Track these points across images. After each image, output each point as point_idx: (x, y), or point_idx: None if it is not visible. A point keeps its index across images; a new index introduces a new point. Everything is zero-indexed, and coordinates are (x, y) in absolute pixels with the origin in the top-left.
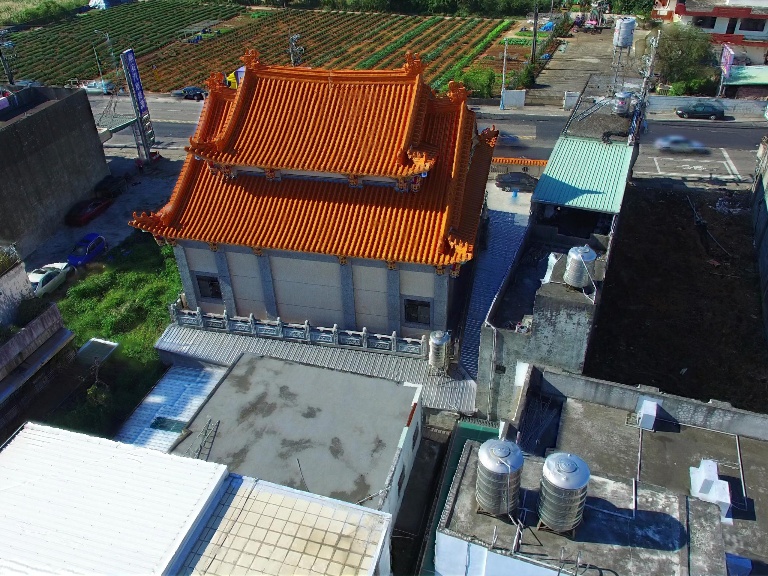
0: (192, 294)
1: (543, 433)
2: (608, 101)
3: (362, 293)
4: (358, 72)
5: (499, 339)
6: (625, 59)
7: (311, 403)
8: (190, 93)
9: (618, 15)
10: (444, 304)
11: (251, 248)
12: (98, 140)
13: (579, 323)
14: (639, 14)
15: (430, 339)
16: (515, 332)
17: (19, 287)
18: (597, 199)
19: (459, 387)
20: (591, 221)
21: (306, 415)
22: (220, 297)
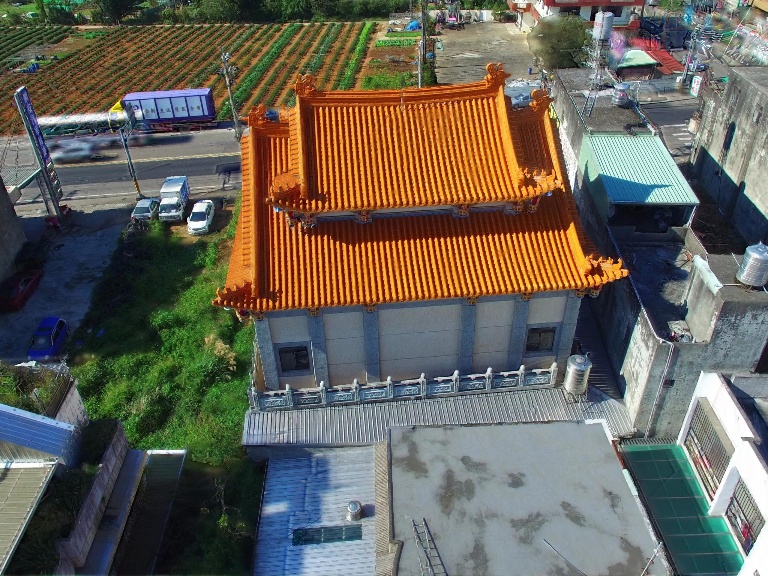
0: (273, 371)
1: (764, 442)
2: (596, 94)
3: (482, 331)
4: (433, 89)
5: (675, 353)
6: (503, 52)
7: (508, 469)
8: (100, 131)
9: (474, 10)
10: (573, 326)
11: (363, 305)
12: (9, 202)
13: (763, 322)
14: (495, 8)
15: (569, 366)
16: (692, 343)
17: (74, 412)
18: (670, 192)
19: (604, 409)
20: (646, 214)
21: (513, 485)
22: (306, 367)
